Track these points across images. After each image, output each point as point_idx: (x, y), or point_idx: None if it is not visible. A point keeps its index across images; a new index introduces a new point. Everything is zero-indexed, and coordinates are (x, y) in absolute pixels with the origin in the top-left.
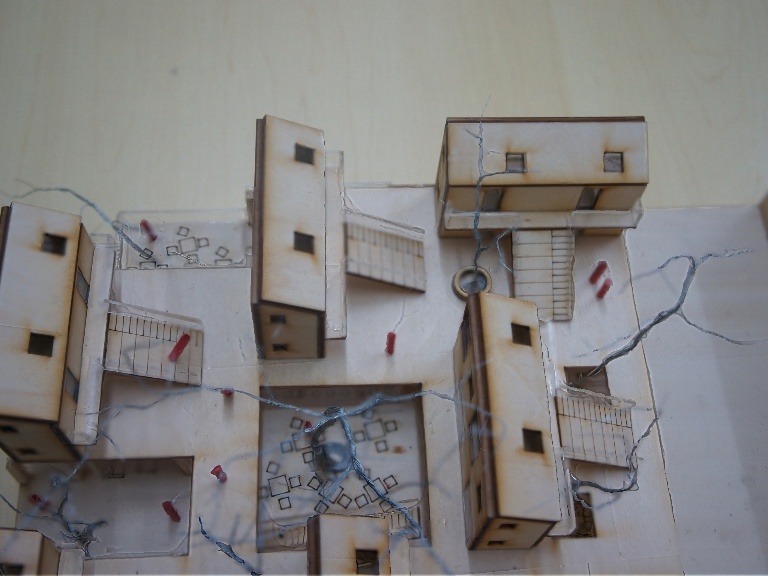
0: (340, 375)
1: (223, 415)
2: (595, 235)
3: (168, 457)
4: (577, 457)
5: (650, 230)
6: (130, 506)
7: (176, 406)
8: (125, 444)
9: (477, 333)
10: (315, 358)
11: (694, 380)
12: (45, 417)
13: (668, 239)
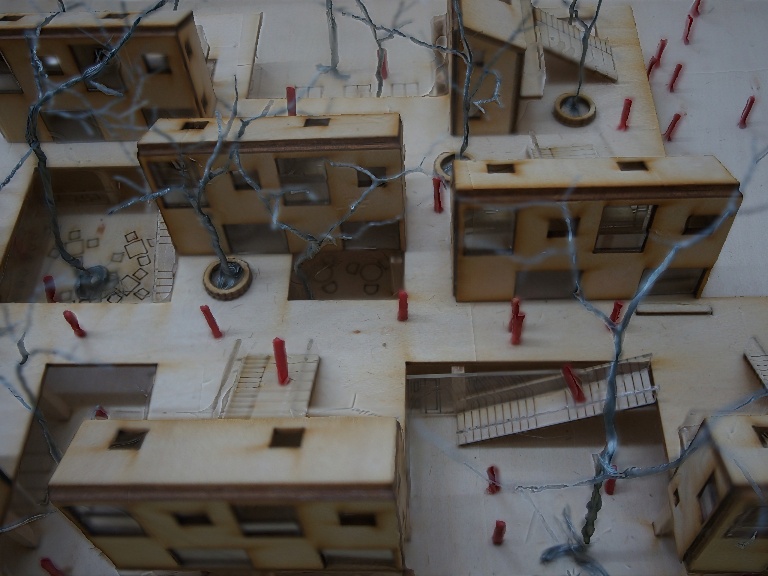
0: (1, 232)
1: (7, 337)
2: None
3: (39, 391)
4: None
5: None
6: None
7: None
8: (8, 437)
9: None
10: None
11: None
12: None
13: None
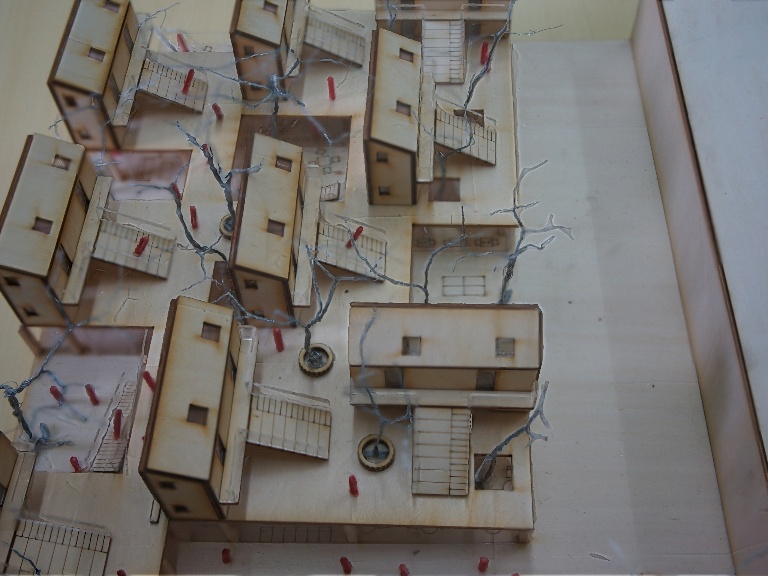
0: (297, 110)
1: (215, 129)
2: (490, 37)
3: (176, 150)
4: (446, 144)
5: (544, 53)
6: (151, 196)
7: (184, 123)
8: (149, 142)
9: (374, 49)
10: (281, 101)
11: (561, 140)
12: (94, 90)
13: (556, 58)
